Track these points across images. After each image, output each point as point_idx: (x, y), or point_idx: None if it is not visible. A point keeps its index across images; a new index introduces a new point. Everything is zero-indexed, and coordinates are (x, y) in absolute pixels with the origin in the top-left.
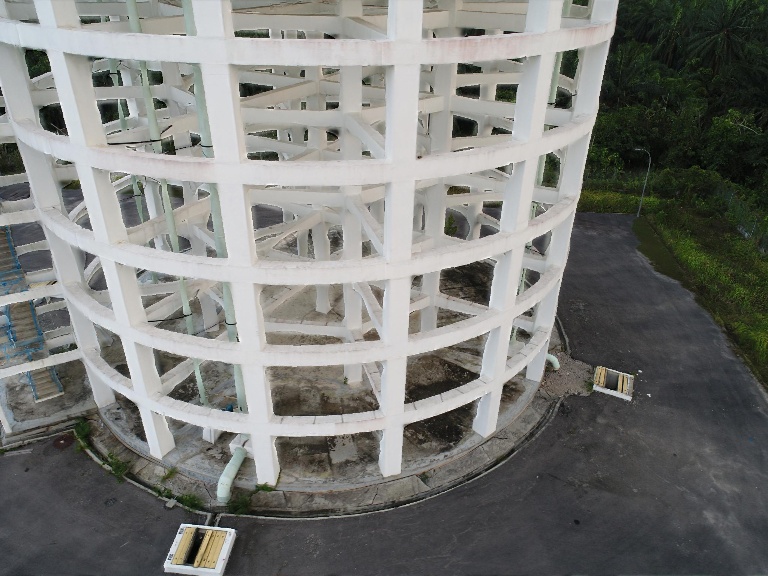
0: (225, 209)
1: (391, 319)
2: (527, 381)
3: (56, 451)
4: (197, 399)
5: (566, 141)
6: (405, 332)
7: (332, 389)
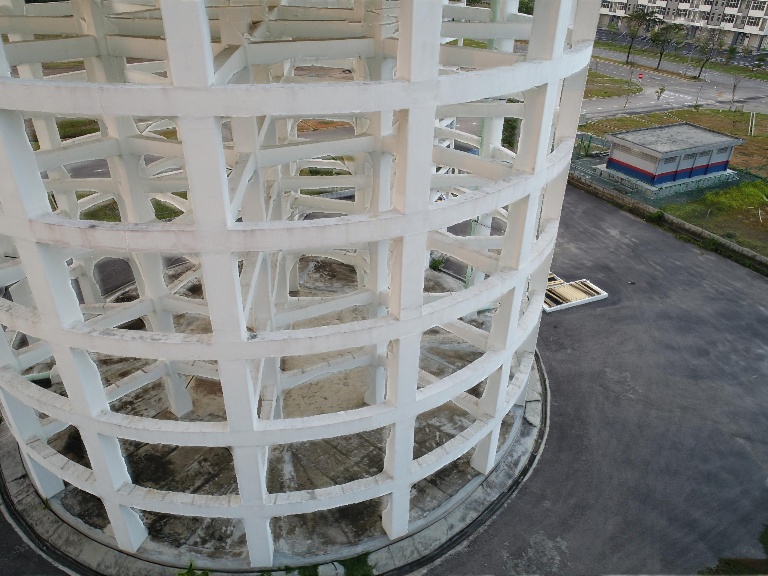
0: None
1: None
2: None
3: None
4: (311, 268)
5: None
6: None
7: None
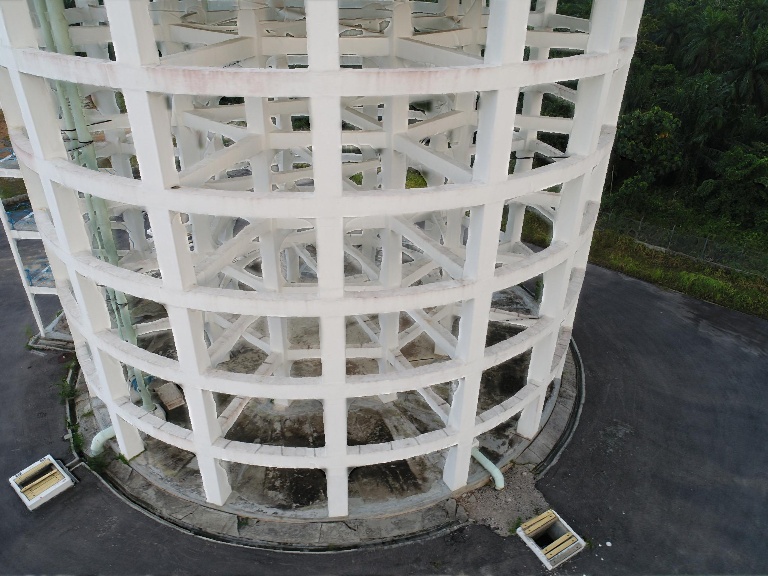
0: (47, 198)
1: (177, 345)
2: (440, 483)
3: (56, 362)
4: None
5: (403, 208)
6: (194, 363)
7: (258, 402)
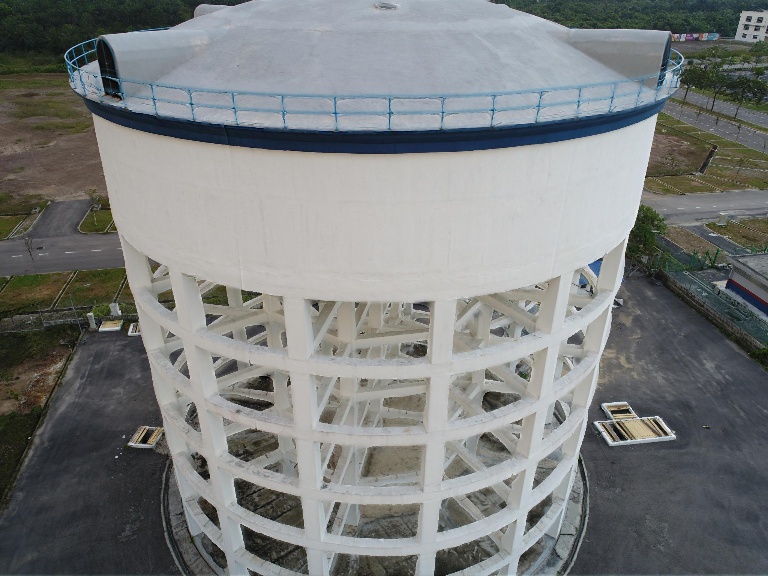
0: None
1: None
2: None
3: None
4: None
5: None
6: None
7: None
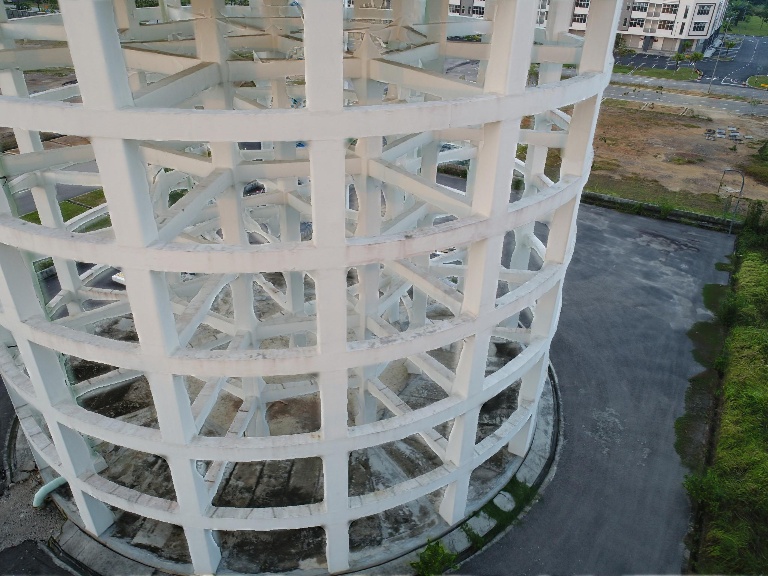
0: None
1: None
2: None
3: None
4: None
5: None
6: None
7: None
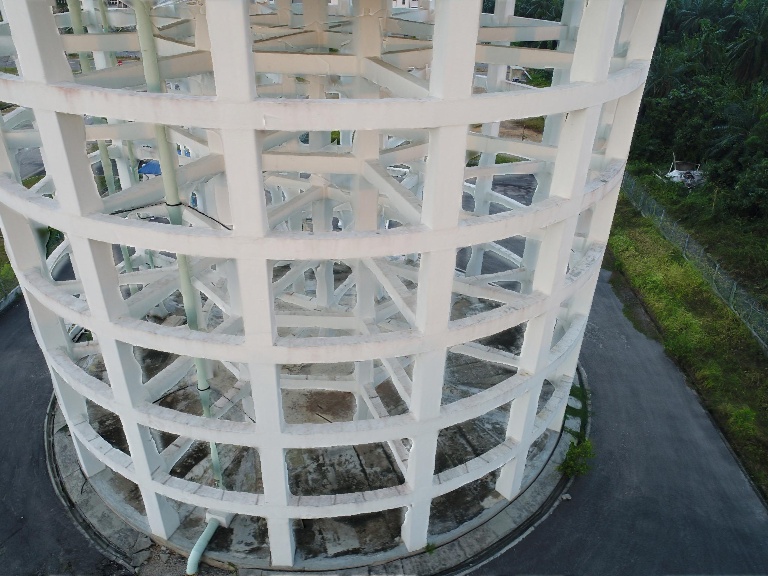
0: None
1: None
2: None
3: None
4: None
5: (12, 204)
6: None
7: (194, 365)
